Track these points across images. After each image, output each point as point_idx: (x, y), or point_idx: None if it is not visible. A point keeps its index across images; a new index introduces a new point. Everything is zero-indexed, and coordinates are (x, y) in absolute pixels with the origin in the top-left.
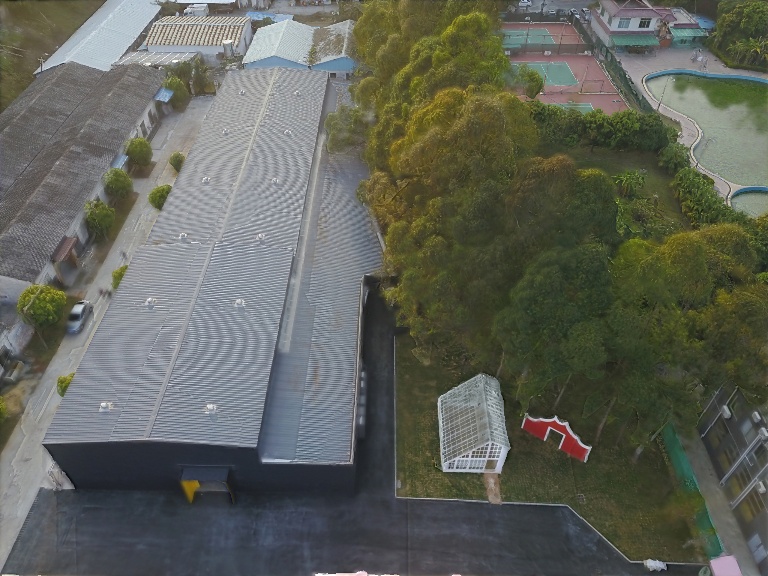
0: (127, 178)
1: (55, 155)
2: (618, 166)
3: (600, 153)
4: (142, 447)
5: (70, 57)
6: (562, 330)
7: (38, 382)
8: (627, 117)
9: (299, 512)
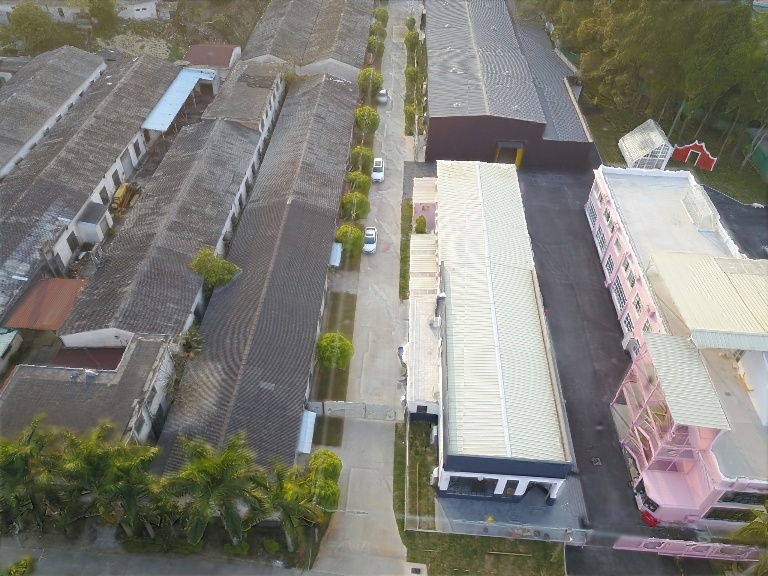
0: (384, 29)
1: (336, 11)
2: None
3: None
4: (483, 123)
5: None
6: (725, 50)
7: None
8: None
9: (555, 176)
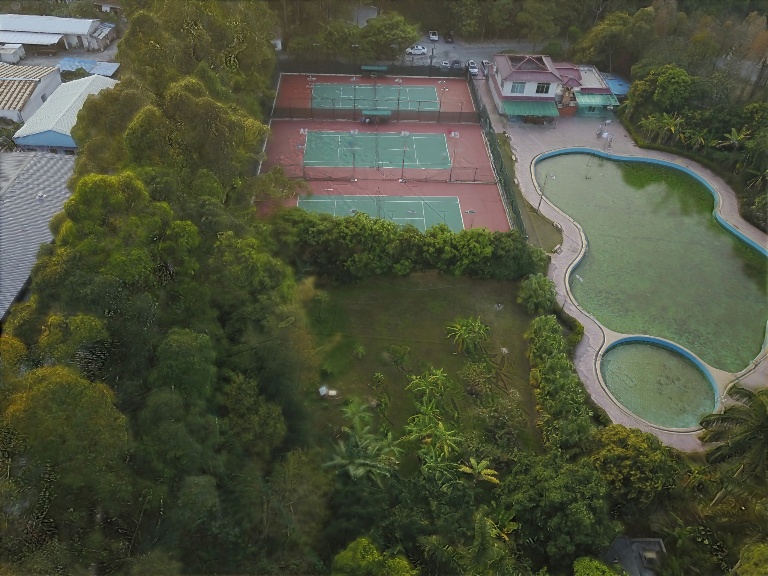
0: None
1: None
2: (468, 298)
3: (449, 277)
4: None
5: None
6: None
7: None
8: (476, 239)
9: None
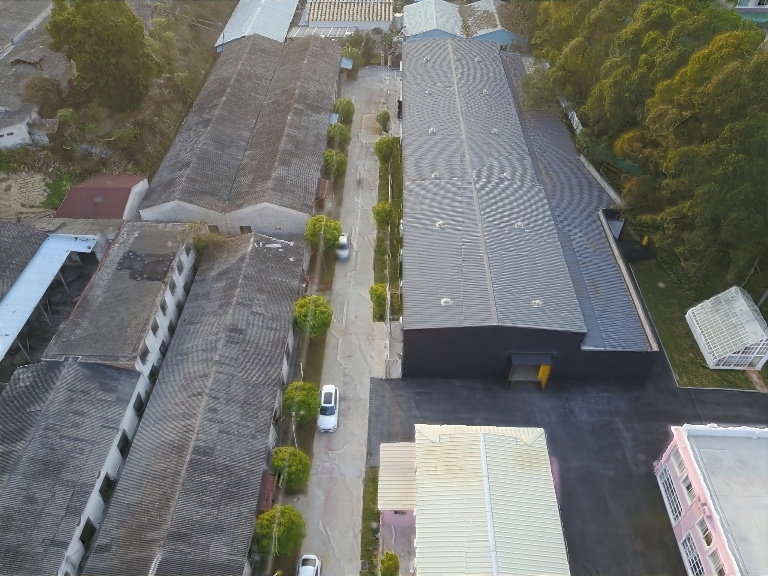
0: None
1: (282, 112)
2: None
3: None
4: (487, 333)
5: (248, 30)
6: None
7: (330, 298)
8: None
9: (601, 396)
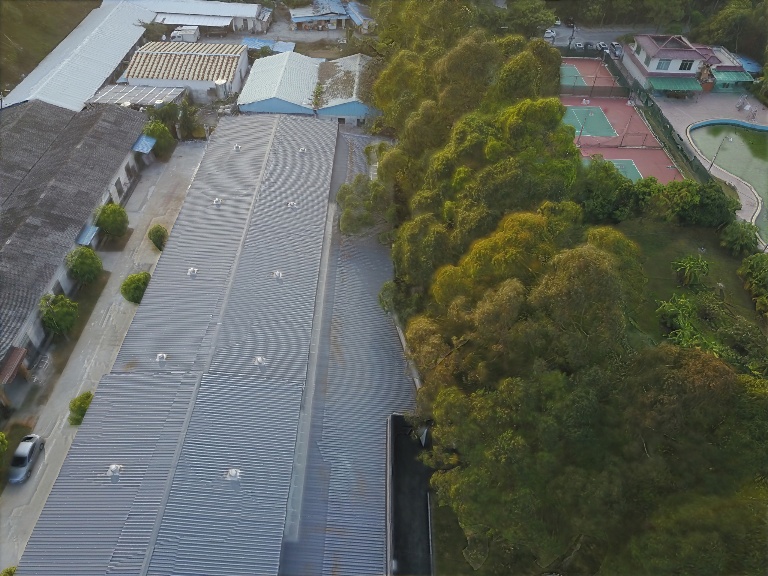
0: (95, 259)
1: (7, 229)
2: (672, 243)
3: (650, 225)
4: None
5: (36, 92)
6: None
7: None
8: (686, 189)
9: None
